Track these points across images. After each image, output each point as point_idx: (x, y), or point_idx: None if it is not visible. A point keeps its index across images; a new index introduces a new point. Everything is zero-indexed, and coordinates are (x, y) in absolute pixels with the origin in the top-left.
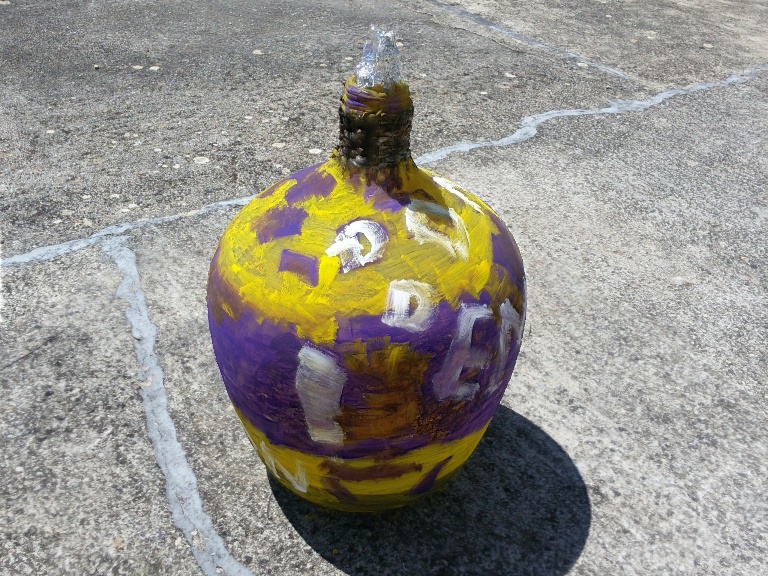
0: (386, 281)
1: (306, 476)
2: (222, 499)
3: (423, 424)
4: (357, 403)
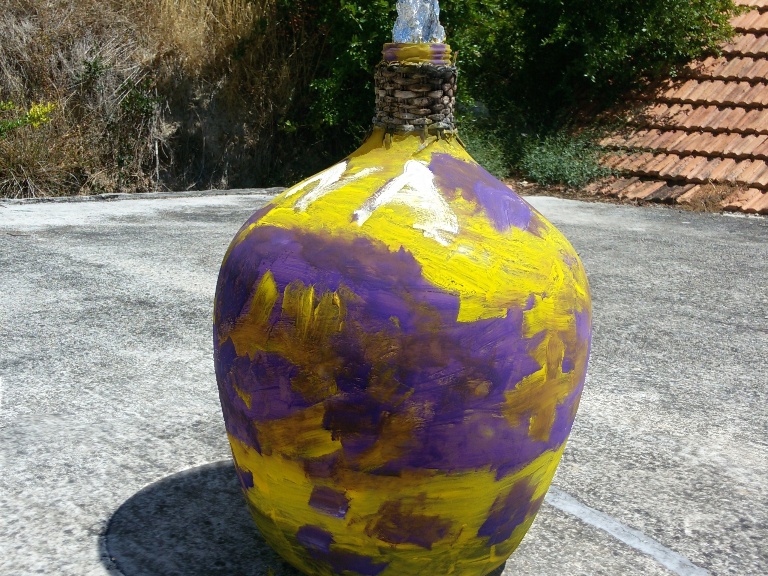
0: None
1: None
2: None
3: None
4: None
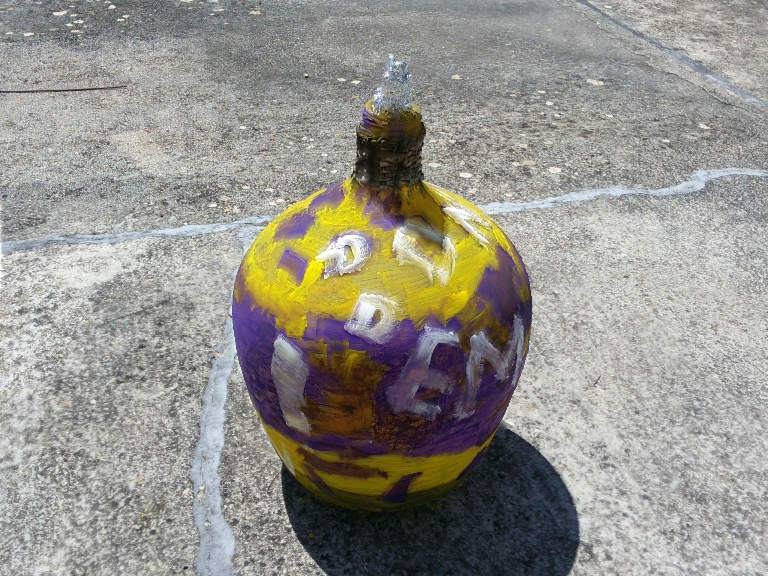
0: (357, 292)
1: (291, 459)
2: (237, 466)
3: (380, 432)
4: (317, 398)
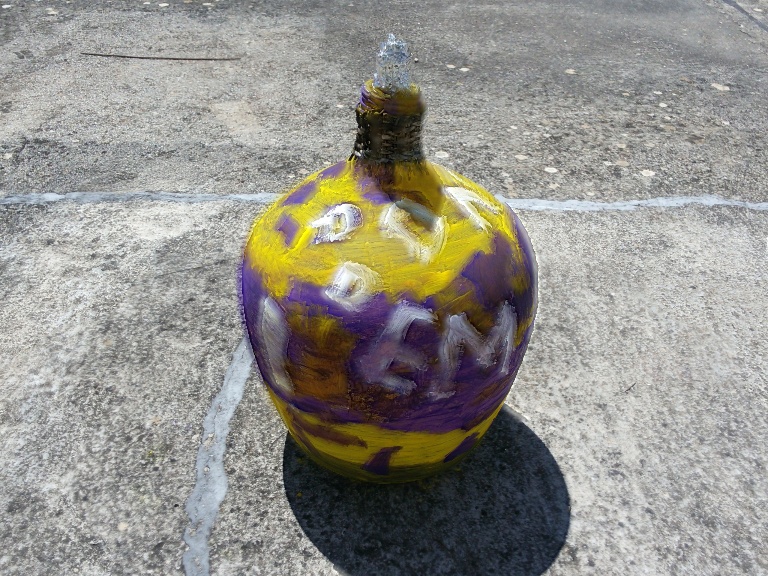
0: (343, 260)
1: (285, 418)
2: (248, 420)
3: (356, 400)
4: (299, 359)
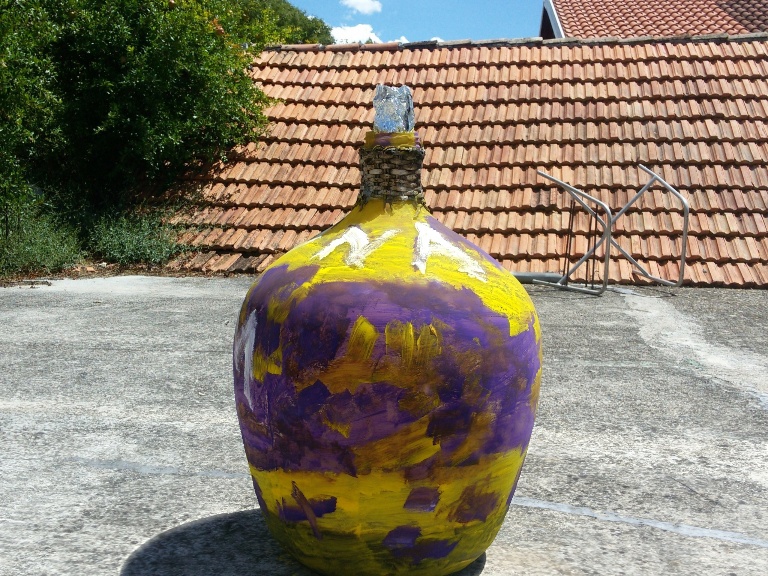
0: None
1: None
2: None
3: None
4: None
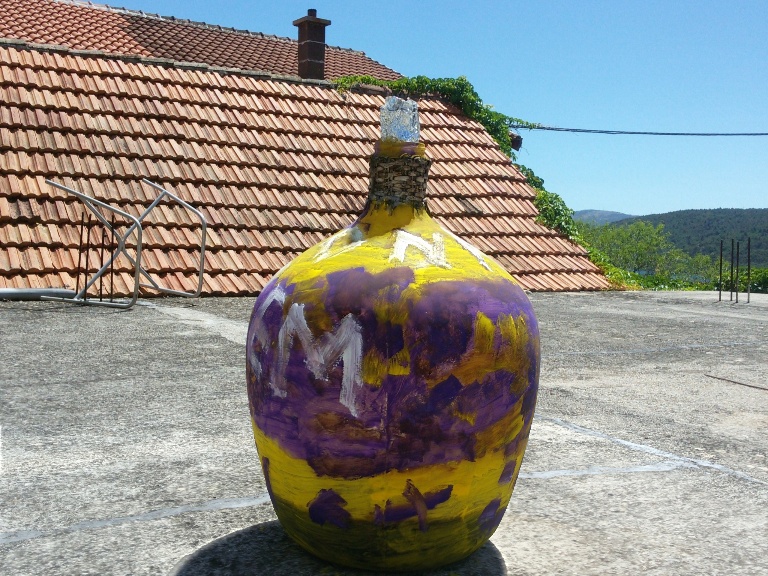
0: None
1: None
2: None
3: None
4: None
